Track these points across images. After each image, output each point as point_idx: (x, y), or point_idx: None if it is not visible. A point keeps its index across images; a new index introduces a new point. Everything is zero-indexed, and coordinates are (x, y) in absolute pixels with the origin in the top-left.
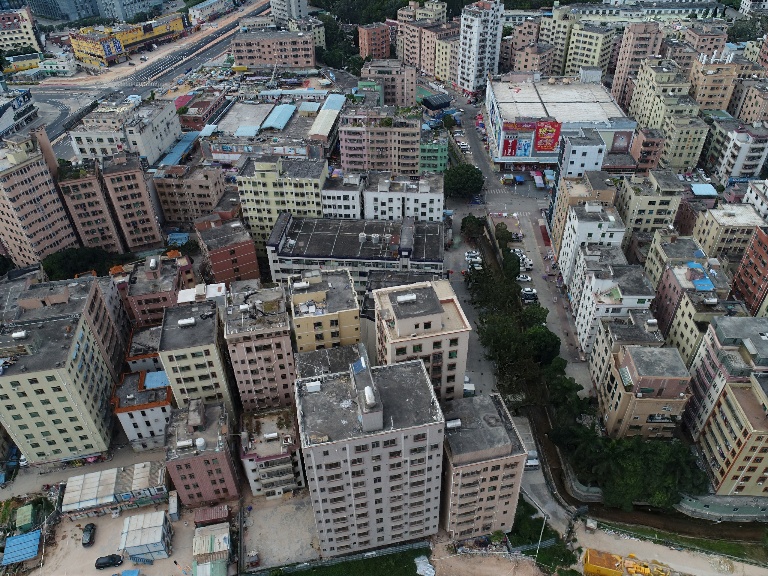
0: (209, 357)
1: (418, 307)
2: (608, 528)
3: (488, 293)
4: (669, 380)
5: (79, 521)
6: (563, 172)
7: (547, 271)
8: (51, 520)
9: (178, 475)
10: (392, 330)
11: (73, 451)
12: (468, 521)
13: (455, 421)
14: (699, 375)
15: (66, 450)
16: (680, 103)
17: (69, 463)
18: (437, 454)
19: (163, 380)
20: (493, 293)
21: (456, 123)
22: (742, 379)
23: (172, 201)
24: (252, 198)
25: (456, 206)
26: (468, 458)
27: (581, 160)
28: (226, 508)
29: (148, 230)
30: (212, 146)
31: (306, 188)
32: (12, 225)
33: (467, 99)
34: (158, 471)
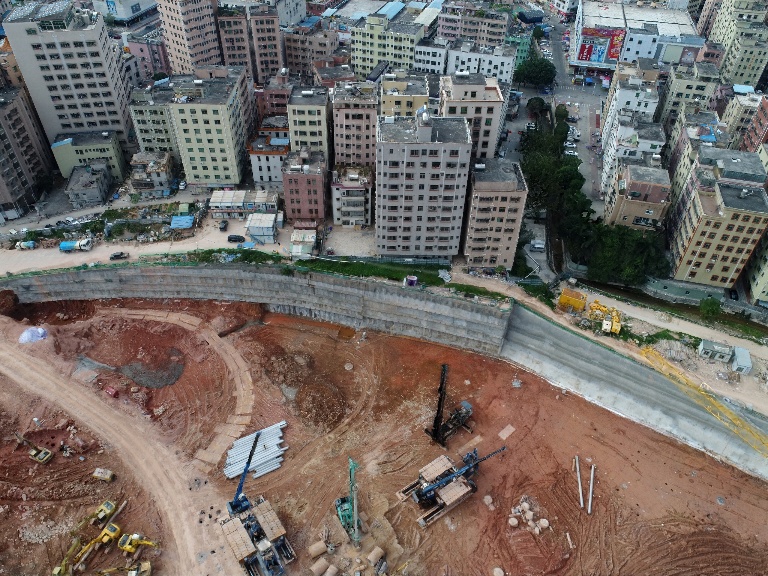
0: (319, 117)
1: (469, 81)
2: (585, 287)
3: (535, 142)
4: (653, 186)
5: (217, 219)
6: (620, 59)
7: (592, 143)
8: (200, 214)
9: (288, 188)
10: (449, 97)
11: (217, 179)
12: (480, 249)
13: (481, 164)
14: (683, 196)
15: (213, 177)
16: (752, 28)
17: (212, 190)
18: (464, 174)
19: (283, 143)
20: (539, 140)
21: (545, 35)
22: (710, 189)
23: (295, 55)
24: (360, 48)
25: (527, 93)
26: (486, 187)
27: (636, 48)
28: (315, 222)
29: (276, 70)
30: (331, 24)
31: (404, 42)
32: (181, 46)
33: (560, 19)
34: (273, 196)
